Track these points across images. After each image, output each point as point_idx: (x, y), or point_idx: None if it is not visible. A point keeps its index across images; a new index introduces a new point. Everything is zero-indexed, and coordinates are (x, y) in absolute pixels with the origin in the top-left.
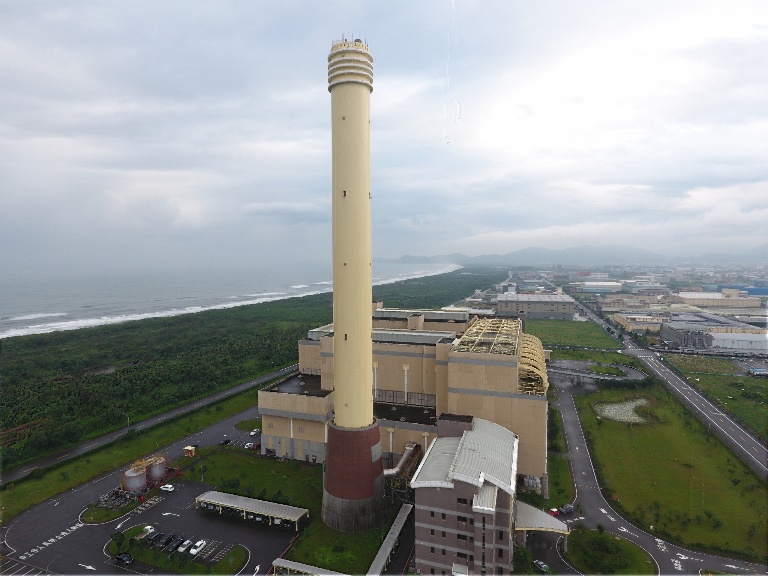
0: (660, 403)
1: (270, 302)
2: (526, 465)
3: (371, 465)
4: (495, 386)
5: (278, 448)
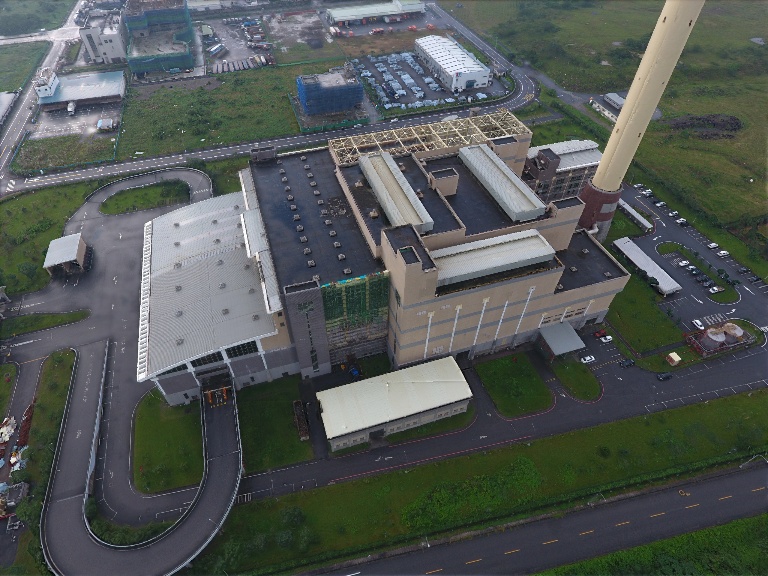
0: None
1: None
2: None
3: None
4: None
5: None
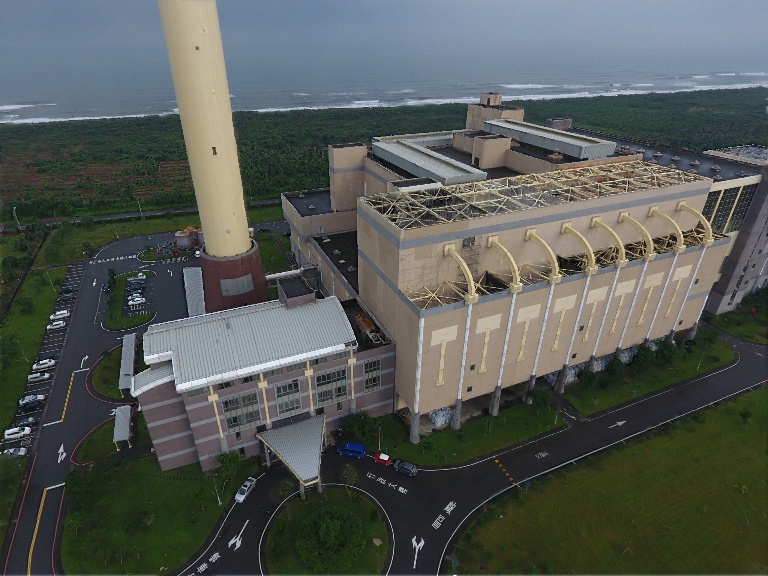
0: None
1: (607, 97)
2: (402, 388)
3: (221, 297)
4: (384, 267)
5: (296, 254)
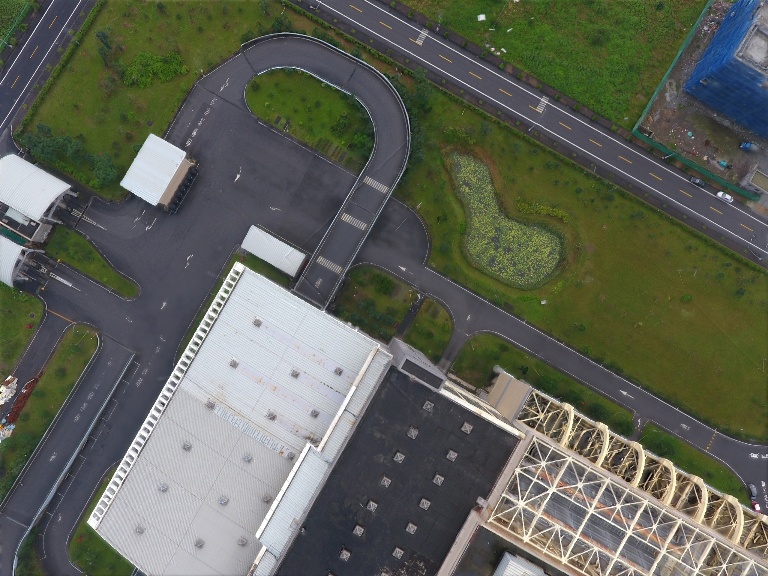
0: (496, 159)
1: None
2: None
3: None
4: None
5: None
